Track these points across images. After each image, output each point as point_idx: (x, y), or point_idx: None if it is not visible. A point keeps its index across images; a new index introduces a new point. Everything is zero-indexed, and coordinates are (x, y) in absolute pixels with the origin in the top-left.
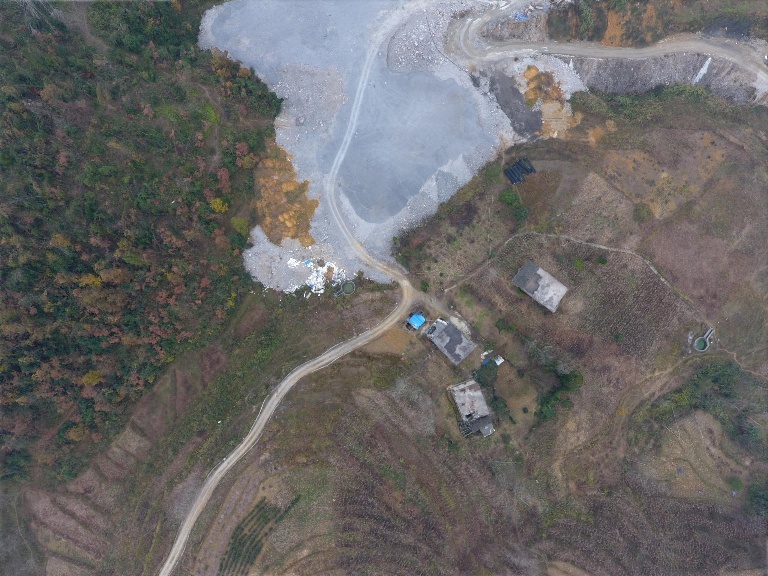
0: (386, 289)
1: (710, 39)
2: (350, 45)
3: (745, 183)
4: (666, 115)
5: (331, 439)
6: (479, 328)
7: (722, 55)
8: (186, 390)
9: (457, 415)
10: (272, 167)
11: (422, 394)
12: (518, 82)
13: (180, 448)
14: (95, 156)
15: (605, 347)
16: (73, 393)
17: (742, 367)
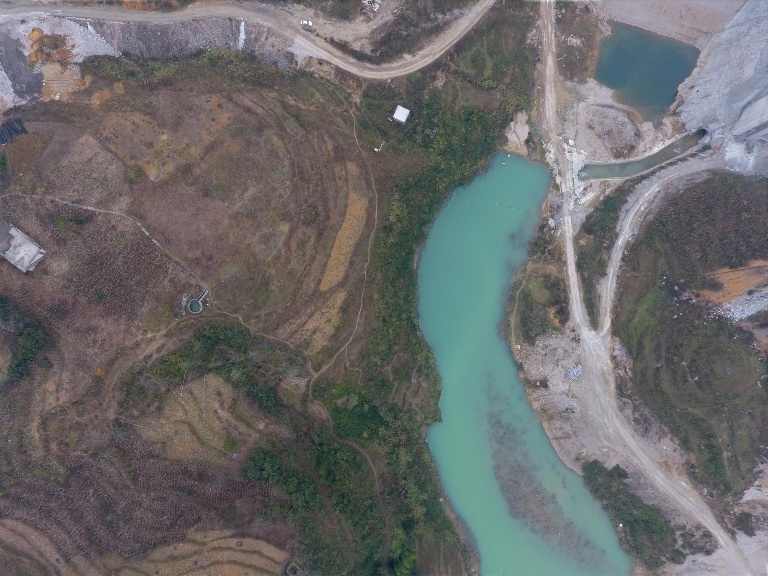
0: None
1: (244, 4)
2: None
3: (251, 146)
4: (177, 78)
5: None
6: None
7: (256, 20)
8: None
9: None
10: None
11: None
12: (24, 44)
13: None
14: None
15: (91, 308)
16: None
17: (252, 330)
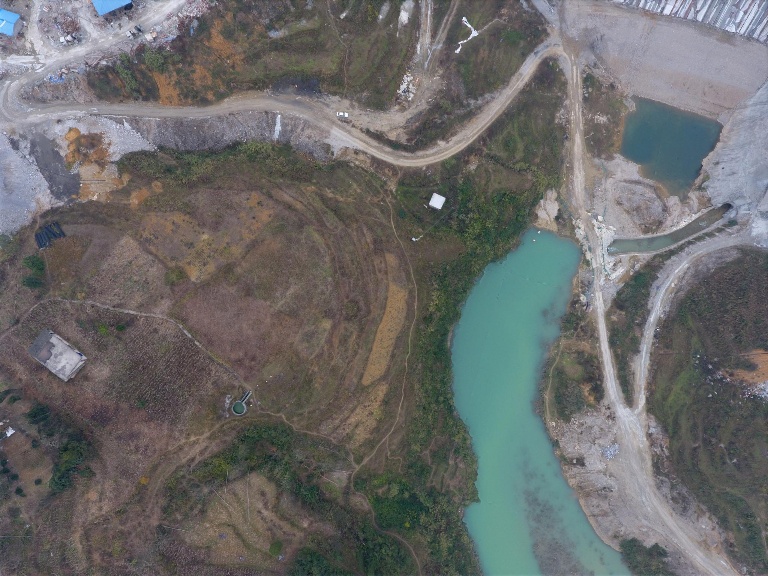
0: None
1: (279, 96)
2: None
3: (292, 243)
4: (216, 175)
5: None
6: None
7: (292, 112)
8: None
9: None
10: None
11: None
12: (60, 144)
13: None
14: None
15: (133, 414)
16: None
17: (295, 428)
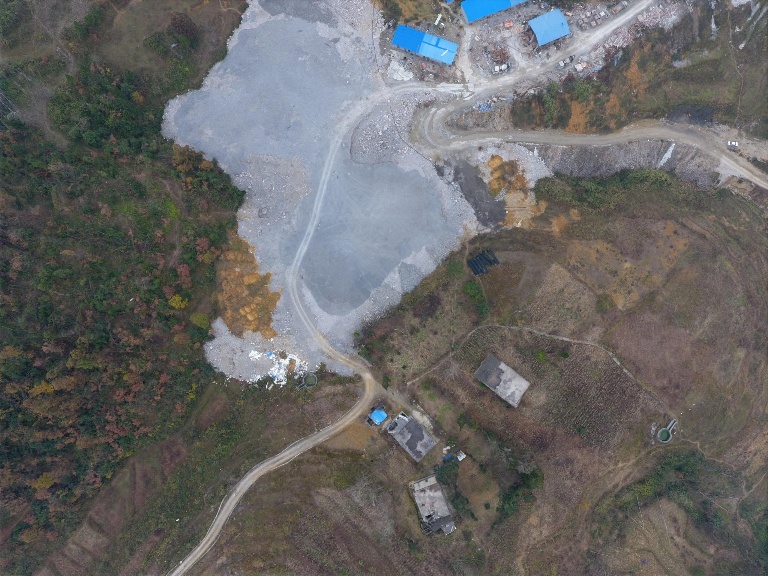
0: (348, 382)
1: (674, 125)
2: (314, 136)
3: (707, 272)
4: (629, 204)
5: (289, 542)
6: (441, 422)
7: (686, 141)
8: (145, 484)
9: (418, 512)
10: (234, 259)
11: (382, 493)
12: (482, 171)
13: (137, 547)
14: (50, 258)
15: (568, 440)
16: (27, 494)
17: (706, 455)
